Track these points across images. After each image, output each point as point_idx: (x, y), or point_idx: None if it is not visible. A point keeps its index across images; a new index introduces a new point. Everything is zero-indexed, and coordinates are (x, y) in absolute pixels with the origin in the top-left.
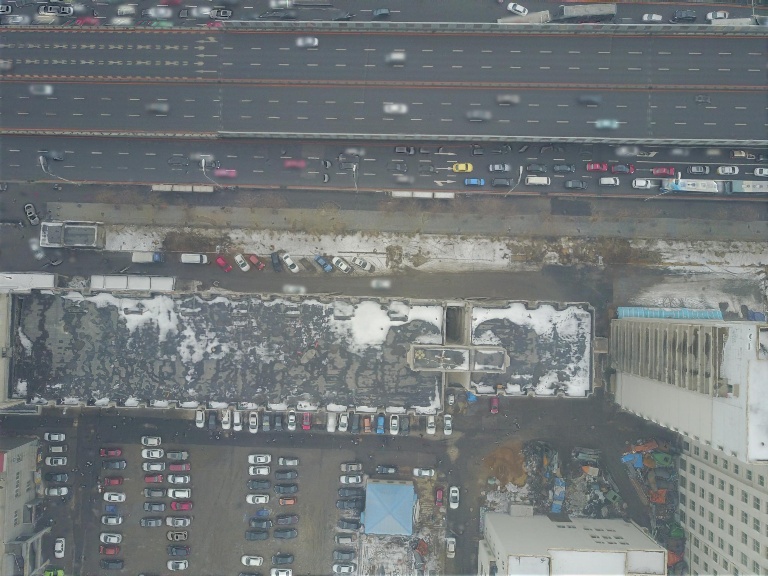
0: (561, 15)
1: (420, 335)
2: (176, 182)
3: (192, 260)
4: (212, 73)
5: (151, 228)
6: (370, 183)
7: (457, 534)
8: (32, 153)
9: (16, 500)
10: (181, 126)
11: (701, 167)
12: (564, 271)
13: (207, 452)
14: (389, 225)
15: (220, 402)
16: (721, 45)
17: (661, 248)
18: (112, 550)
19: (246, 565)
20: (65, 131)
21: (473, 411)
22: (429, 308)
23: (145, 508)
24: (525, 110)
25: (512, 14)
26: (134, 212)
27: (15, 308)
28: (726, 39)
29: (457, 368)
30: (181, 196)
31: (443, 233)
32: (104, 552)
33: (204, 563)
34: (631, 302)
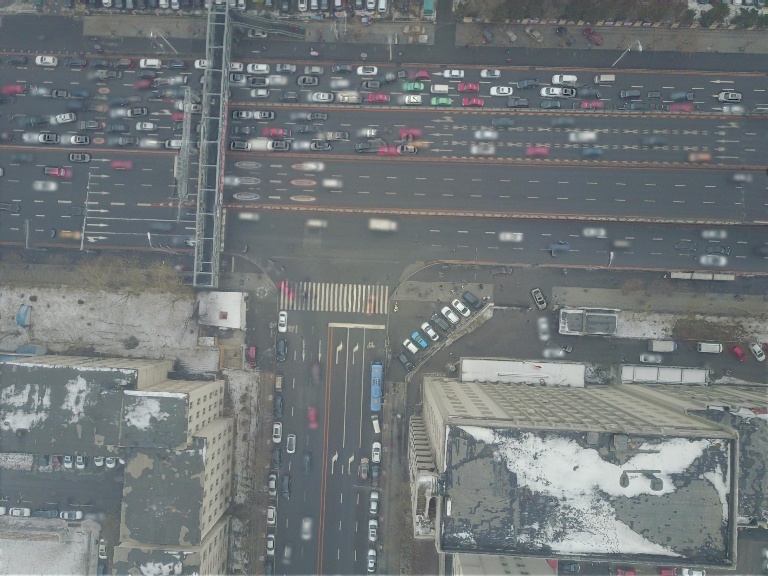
0: None
1: None
2: (685, 268)
3: (713, 350)
4: (733, 159)
5: (661, 315)
6: None
7: None
8: (536, 236)
9: None
10: (699, 213)
11: None
12: None
13: None
14: None
15: None
16: None
17: None
18: None
19: None
20: (578, 216)
21: None
22: None
23: None
24: None
25: None
26: (642, 298)
27: None
28: None
29: None
30: (692, 283)
31: None
32: None
33: None
34: None
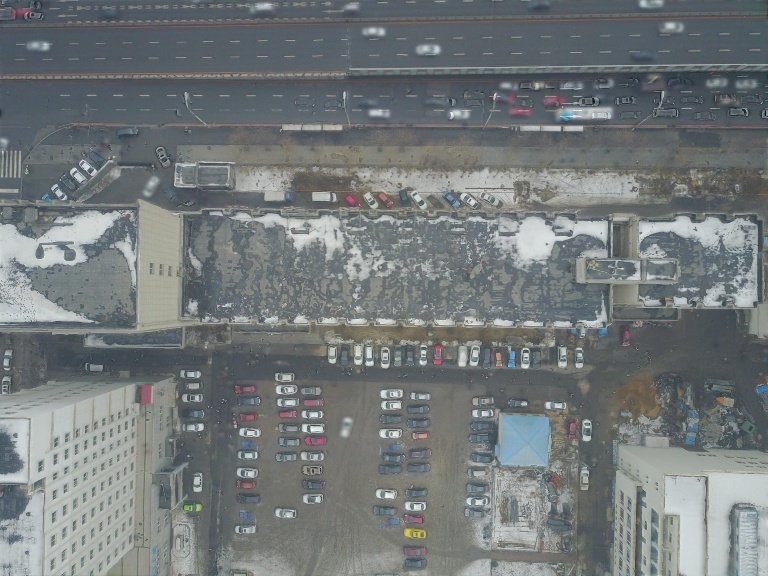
0: None
1: (585, 250)
2: (303, 123)
3: (323, 198)
4: (339, 13)
5: (280, 168)
6: (495, 120)
7: (590, 467)
8: (161, 97)
9: (160, 433)
10: (309, 66)
11: None
12: (693, 203)
13: (339, 388)
14: (516, 161)
15: (387, 319)
16: None
17: None
18: (249, 484)
19: (381, 498)
20: (195, 74)
21: (604, 344)
22: (594, 223)
23: (280, 443)
24: (656, 40)
25: None
26: (262, 153)
27: (185, 229)
28: None
29: (629, 279)
30: (309, 136)
31: (570, 167)
32: (241, 486)
33: (339, 497)
34: None
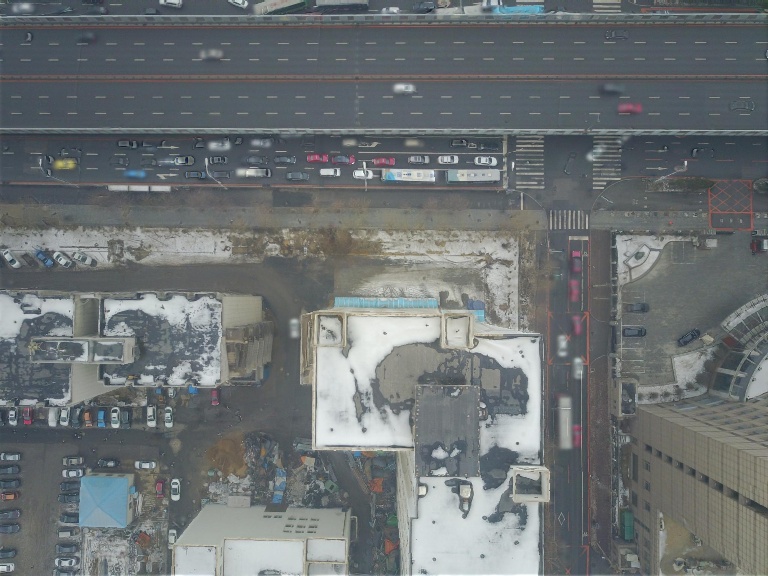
0: (275, 7)
1: (54, 328)
2: None
3: None
4: None
5: None
6: (94, 178)
7: (179, 526)
8: None
9: None
10: None
11: (419, 157)
12: (285, 262)
13: None
14: (111, 219)
15: None
16: (426, 34)
17: (381, 238)
18: None
19: None
20: None
21: (195, 403)
22: (62, 300)
23: None
24: (234, 102)
25: (234, 6)
26: None
27: None
28: (431, 28)
29: (77, 360)
30: None
31: (164, 226)
32: None
33: None
34: (352, 292)
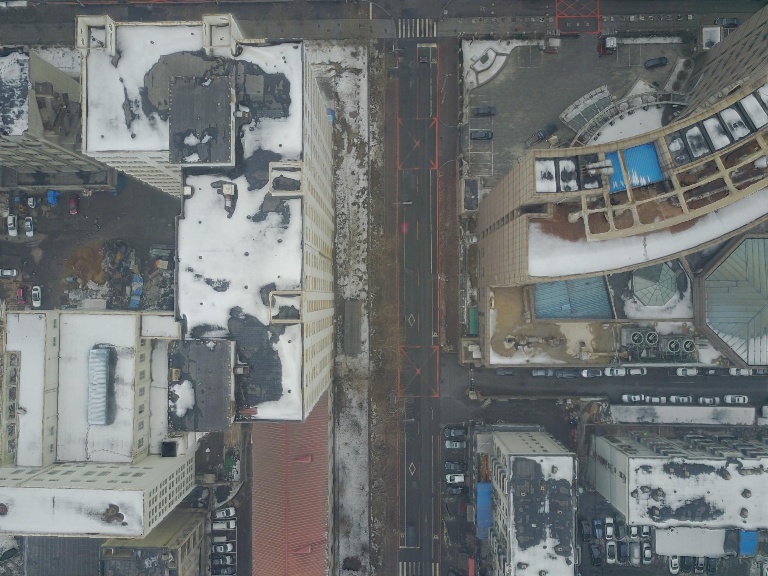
0: None
1: None
2: None
3: None
4: None
5: None
6: None
7: None
8: None
9: None
10: None
11: None
12: None
13: None
14: None
15: None
16: None
17: None
18: None
19: None
20: None
21: (56, 214)
22: None
23: None
24: None
25: None
26: None
27: None
28: None
29: None
30: None
31: (24, 43)
32: None
33: None
34: None
